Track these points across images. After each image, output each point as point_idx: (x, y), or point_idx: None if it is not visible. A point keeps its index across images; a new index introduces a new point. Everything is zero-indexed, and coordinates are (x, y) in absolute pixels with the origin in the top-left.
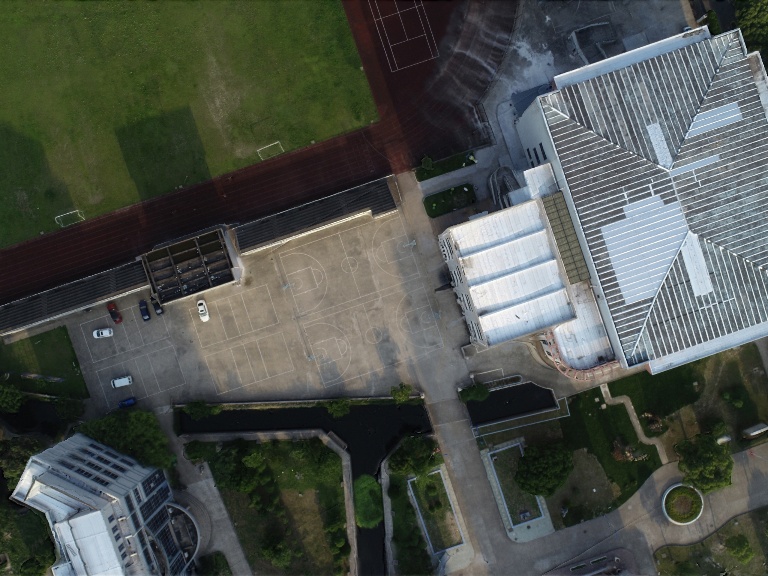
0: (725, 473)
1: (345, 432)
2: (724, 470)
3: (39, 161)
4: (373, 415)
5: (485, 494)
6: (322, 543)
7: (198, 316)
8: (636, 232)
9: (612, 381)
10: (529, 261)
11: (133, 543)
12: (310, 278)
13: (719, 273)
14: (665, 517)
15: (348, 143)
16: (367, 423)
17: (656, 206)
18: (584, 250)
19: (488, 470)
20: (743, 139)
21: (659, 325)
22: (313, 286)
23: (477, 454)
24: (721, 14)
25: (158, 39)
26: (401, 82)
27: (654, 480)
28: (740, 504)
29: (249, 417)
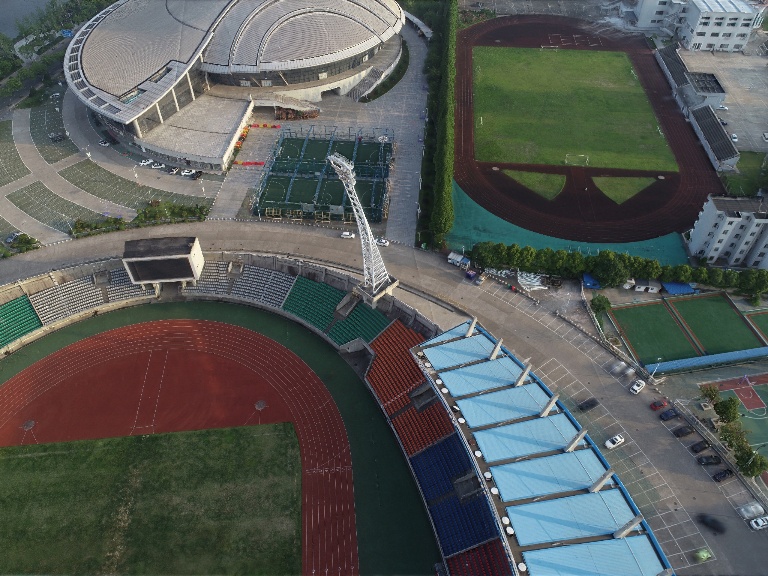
0: None
1: None
2: None
3: (622, 136)
4: None
5: None
6: None
7: (724, 111)
8: None
9: (762, 29)
10: None
11: None
12: None
13: None
14: None
15: (634, 60)
16: None
17: None
18: None
19: None
20: None
21: None
22: None
23: None
24: None
25: None
26: (608, 45)
27: None
28: None
29: None
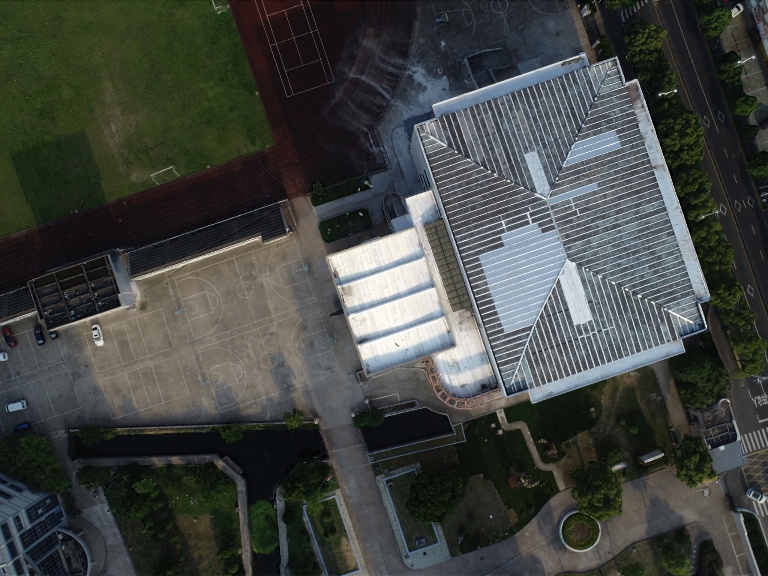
0: (614, 501)
1: (243, 457)
2: (613, 498)
3: None
4: (269, 440)
5: (381, 520)
6: (216, 569)
7: (93, 340)
8: (514, 260)
9: (508, 407)
10: (409, 289)
11: (7, 572)
12: (205, 303)
13: (598, 302)
14: (562, 544)
15: (243, 168)
16: (263, 448)
17: (534, 234)
18: (464, 278)
19: (384, 496)
20: (622, 167)
21: (538, 354)
22: (208, 311)
23: (373, 480)
24: (616, 39)
25: (54, 64)
26: (296, 107)
27: (551, 506)
28: (638, 531)
29: (144, 442)
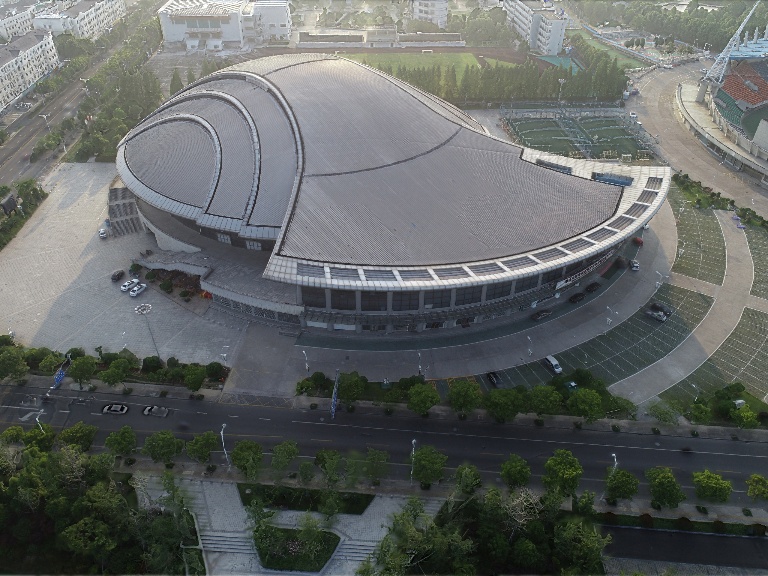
0: None
1: None
2: None
3: None
4: None
5: None
6: None
7: None
8: (227, 1)
9: None
10: None
11: None
12: None
13: None
14: None
15: None
16: None
17: None
18: (244, 6)
19: None
20: None
21: None
22: None
23: None
24: None
25: None
26: None
27: None
28: None
29: None
